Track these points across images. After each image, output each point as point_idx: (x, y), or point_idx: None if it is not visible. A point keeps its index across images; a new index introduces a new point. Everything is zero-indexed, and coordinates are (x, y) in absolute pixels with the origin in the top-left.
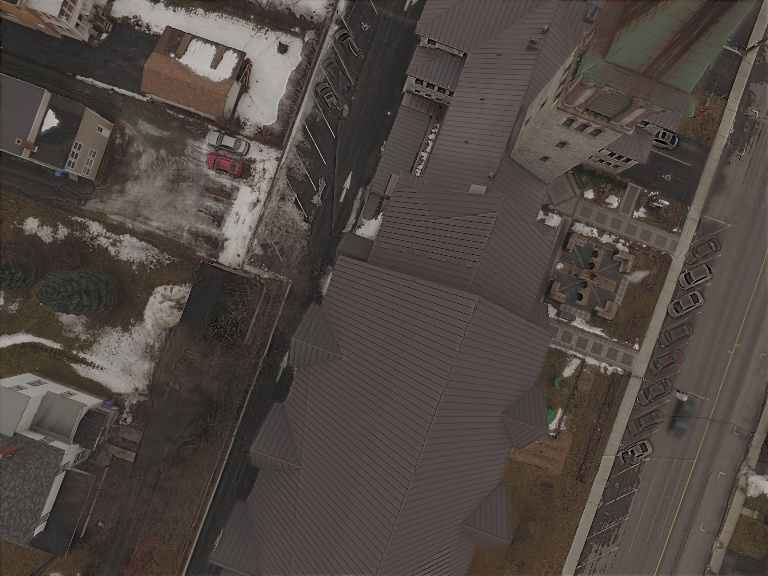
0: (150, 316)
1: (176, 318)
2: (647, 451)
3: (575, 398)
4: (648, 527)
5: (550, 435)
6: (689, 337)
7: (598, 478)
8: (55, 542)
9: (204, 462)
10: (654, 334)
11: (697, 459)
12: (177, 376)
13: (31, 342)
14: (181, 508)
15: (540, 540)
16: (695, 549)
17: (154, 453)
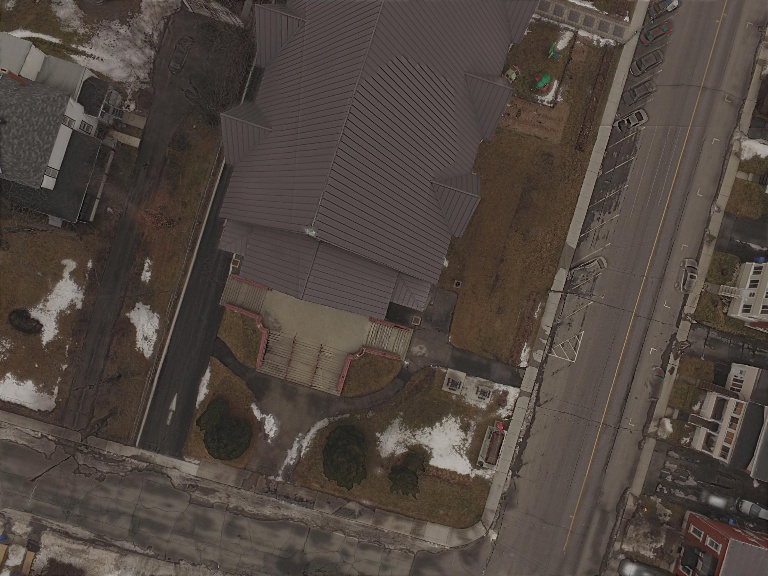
0: (147, 6)
1: (173, 4)
2: (642, 120)
3: (570, 70)
4: (647, 193)
5: (548, 106)
6: (677, 8)
7: (596, 147)
8: (65, 204)
9: (209, 146)
10: (643, 7)
11: (691, 126)
12: (178, 56)
13: (30, 37)
14: (189, 192)
15: (543, 209)
16: (694, 213)
17: (159, 139)
